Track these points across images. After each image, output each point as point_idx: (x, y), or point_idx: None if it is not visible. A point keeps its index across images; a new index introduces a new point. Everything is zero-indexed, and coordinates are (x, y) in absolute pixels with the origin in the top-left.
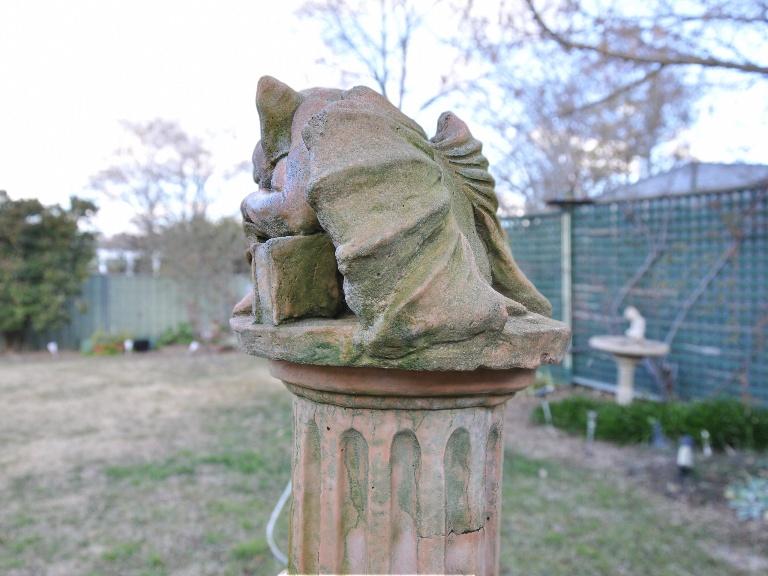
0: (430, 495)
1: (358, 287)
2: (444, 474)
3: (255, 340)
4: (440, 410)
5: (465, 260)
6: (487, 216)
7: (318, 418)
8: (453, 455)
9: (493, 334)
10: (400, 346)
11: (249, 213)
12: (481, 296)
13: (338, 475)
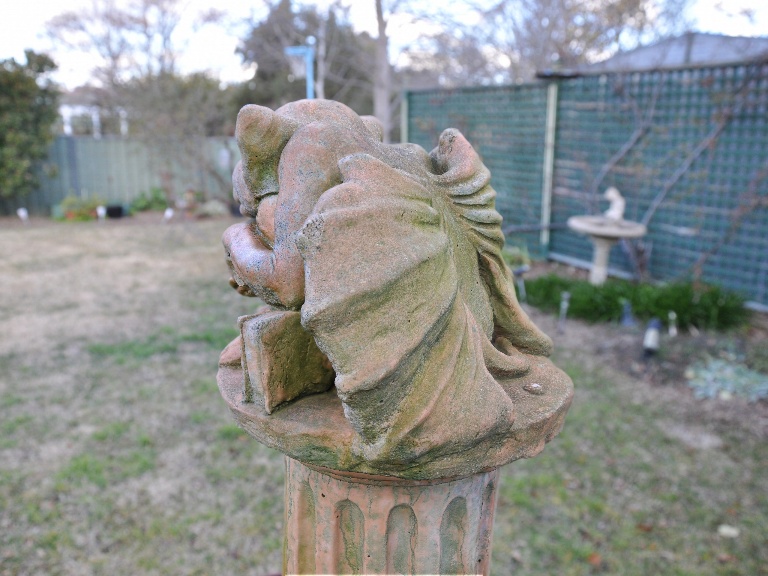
0: (425, 562)
1: (359, 413)
2: (440, 541)
3: (246, 422)
4: (438, 484)
5: (471, 350)
6: (492, 262)
7: (312, 483)
8: (449, 517)
9: (498, 436)
10: (402, 464)
11: (233, 264)
12: (488, 401)
13: (333, 540)
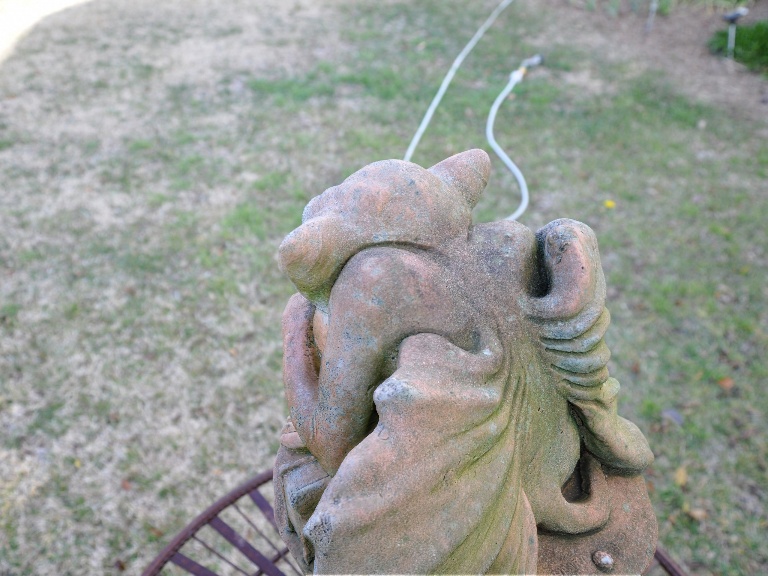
0: None
1: None
2: None
3: None
4: None
5: (521, 572)
6: (586, 408)
7: None
8: None
9: None
10: None
11: None
12: None
13: None
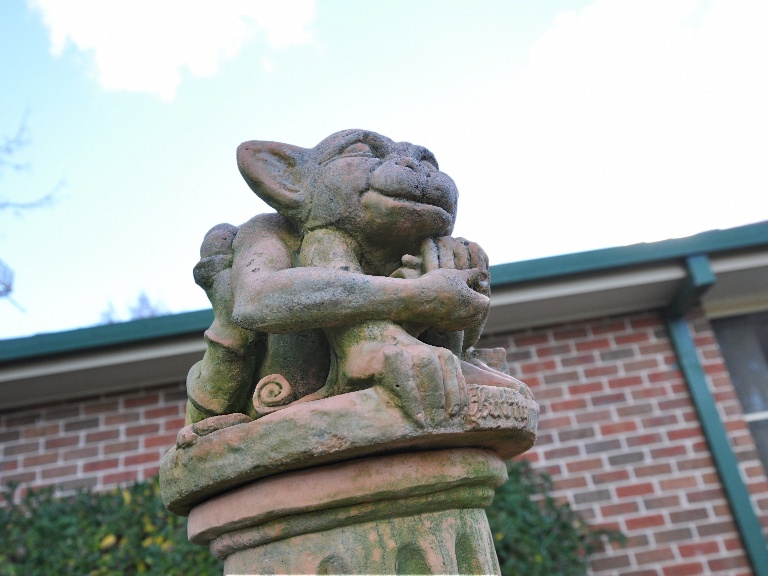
0: None
1: None
2: None
3: None
4: None
5: None
6: None
7: None
8: None
9: None
10: None
11: None
12: None
13: None
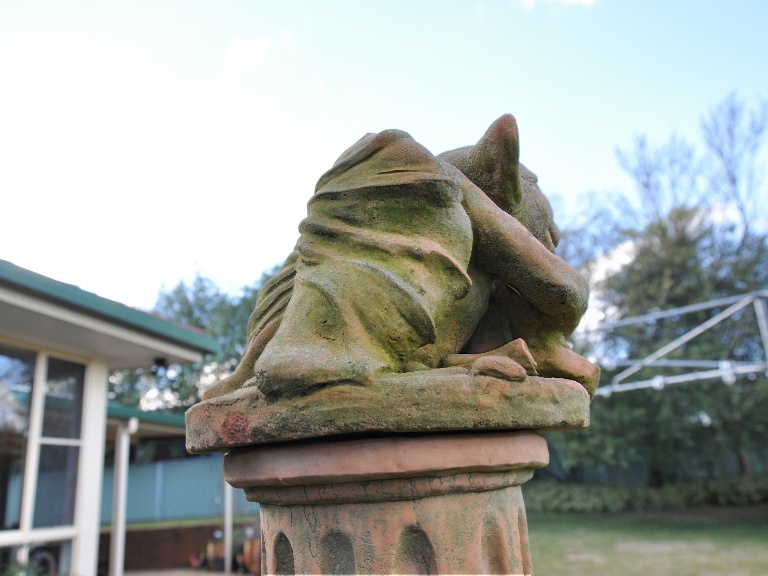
0: None
1: None
2: None
3: None
4: None
5: None
6: None
7: None
8: None
9: None
10: None
11: None
12: None
13: None
